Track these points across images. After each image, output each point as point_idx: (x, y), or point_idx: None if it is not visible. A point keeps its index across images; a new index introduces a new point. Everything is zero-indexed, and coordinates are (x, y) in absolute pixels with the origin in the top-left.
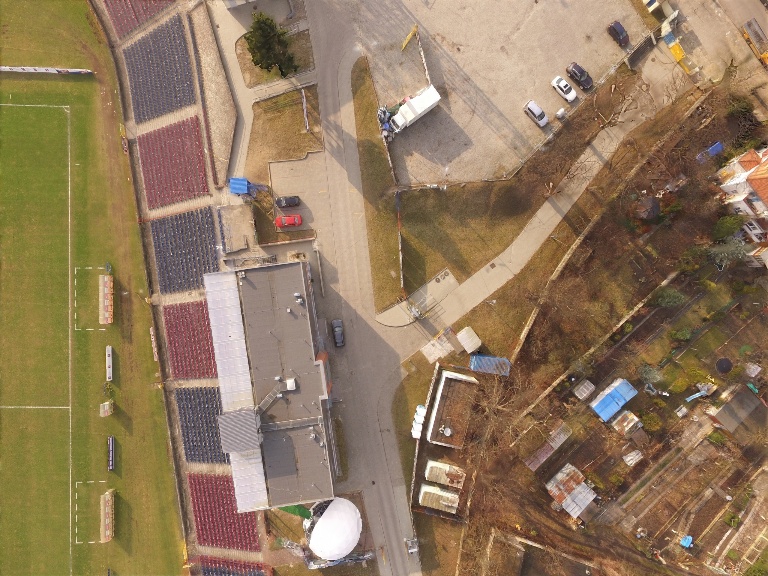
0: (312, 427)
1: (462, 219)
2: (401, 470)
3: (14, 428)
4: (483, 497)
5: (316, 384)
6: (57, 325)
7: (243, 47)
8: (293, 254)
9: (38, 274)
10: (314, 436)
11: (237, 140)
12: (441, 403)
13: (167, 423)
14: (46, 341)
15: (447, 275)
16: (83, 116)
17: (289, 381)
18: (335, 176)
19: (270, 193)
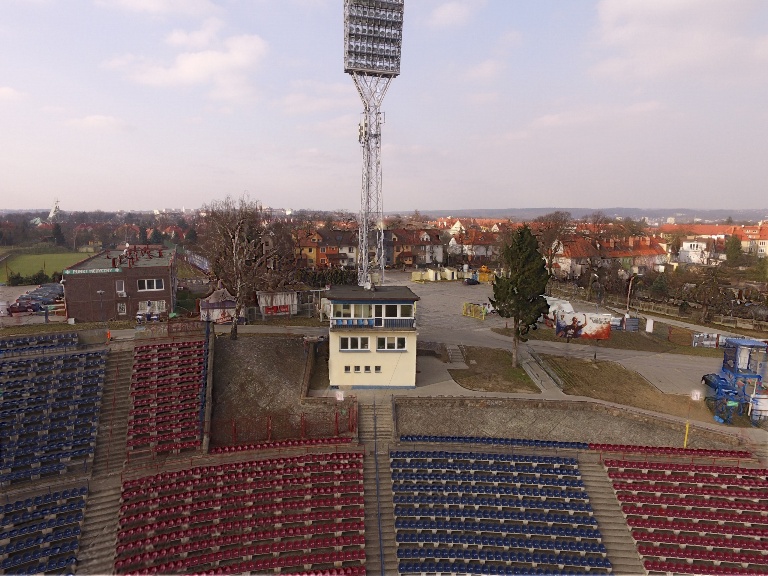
0: None
1: None
2: None
3: None
4: None
5: None
6: None
7: (475, 386)
8: None
9: None
10: None
11: None
12: None
13: None
14: None
15: None
16: None
17: None
18: (647, 362)
19: (717, 399)
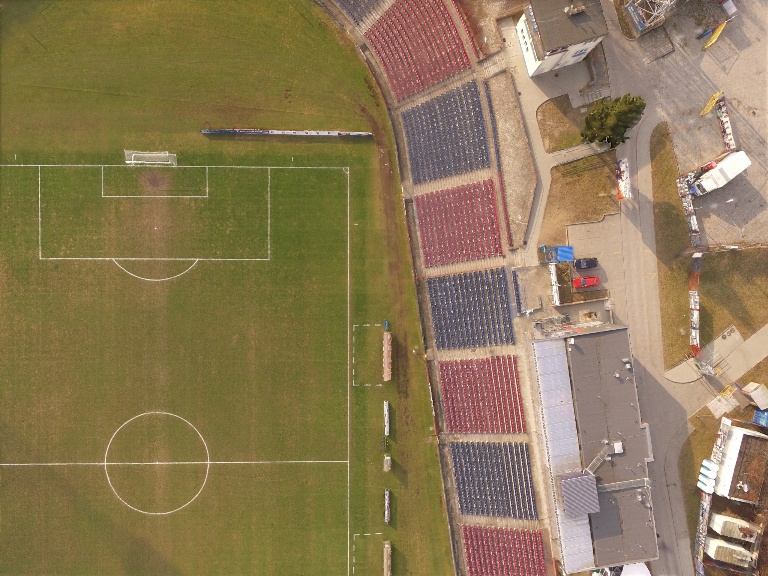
0: (640, 489)
1: (749, 277)
2: (686, 523)
3: (295, 482)
4: (764, 549)
5: (641, 447)
6: (336, 381)
7: (544, 113)
8: (585, 313)
9: (318, 332)
10: (641, 498)
11: (534, 203)
12: (739, 460)
13: (441, 476)
14: (325, 397)
15: (733, 332)
16: (362, 177)
17: (617, 444)
18: (629, 237)
19: None
